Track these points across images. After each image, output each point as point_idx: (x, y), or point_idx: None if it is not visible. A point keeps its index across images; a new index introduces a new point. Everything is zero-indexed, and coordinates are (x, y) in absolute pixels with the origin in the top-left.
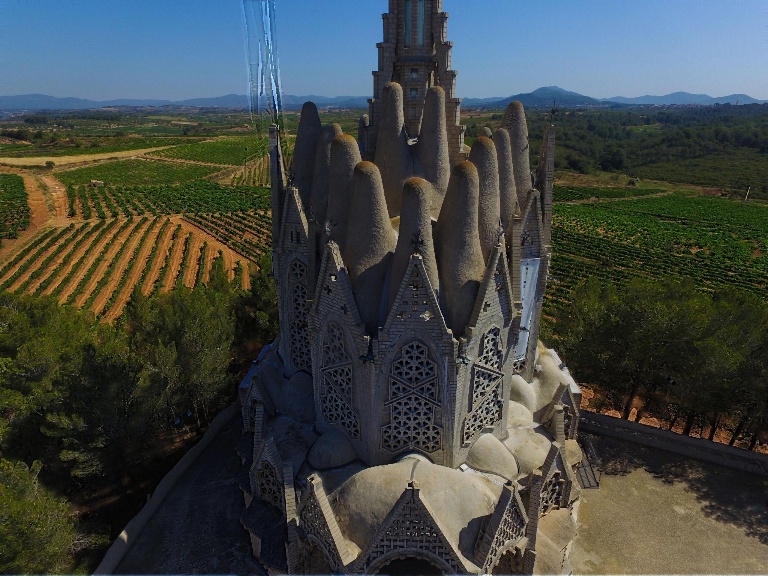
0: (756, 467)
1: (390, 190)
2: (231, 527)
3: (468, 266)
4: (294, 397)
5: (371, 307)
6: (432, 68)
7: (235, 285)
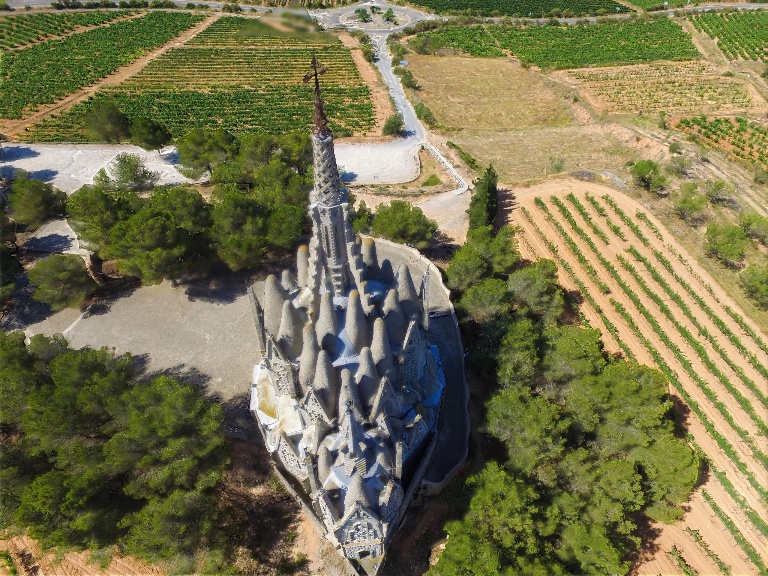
0: None
1: None
2: None
3: None
4: None
5: None
6: None
7: (585, 565)
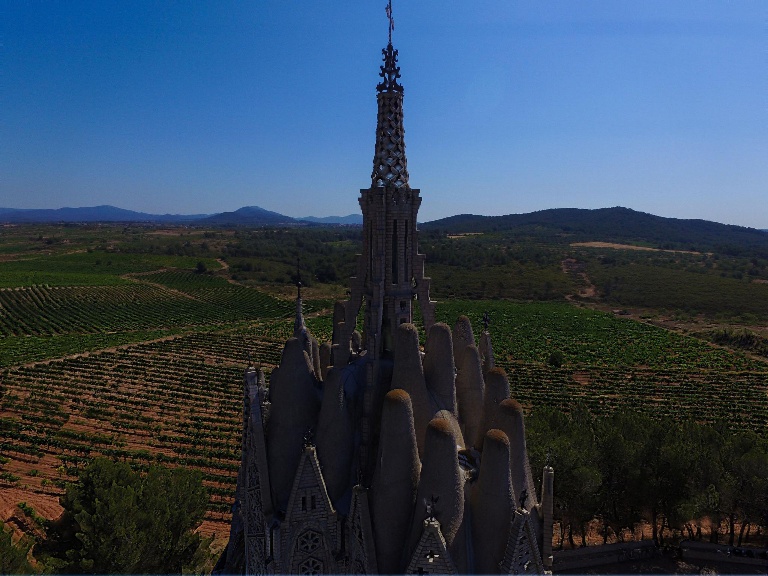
0: (624, 556)
1: (421, 428)
2: None
3: (528, 495)
4: None
5: (464, 573)
6: (411, 298)
7: None
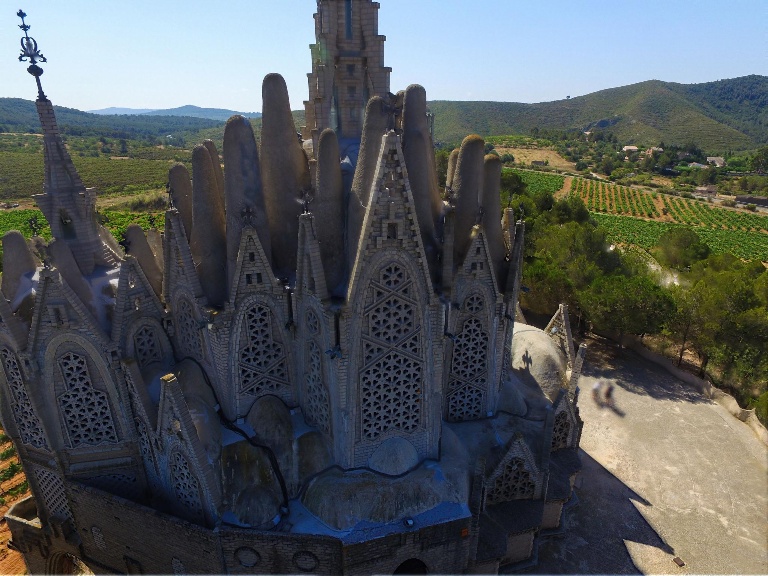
0: None
1: None
2: (547, 574)
3: None
4: (462, 446)
5: None
6: None
7: None
